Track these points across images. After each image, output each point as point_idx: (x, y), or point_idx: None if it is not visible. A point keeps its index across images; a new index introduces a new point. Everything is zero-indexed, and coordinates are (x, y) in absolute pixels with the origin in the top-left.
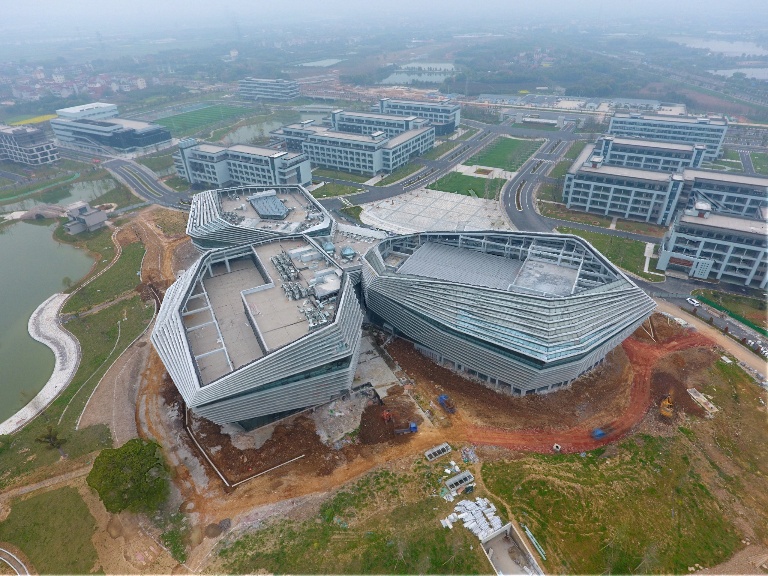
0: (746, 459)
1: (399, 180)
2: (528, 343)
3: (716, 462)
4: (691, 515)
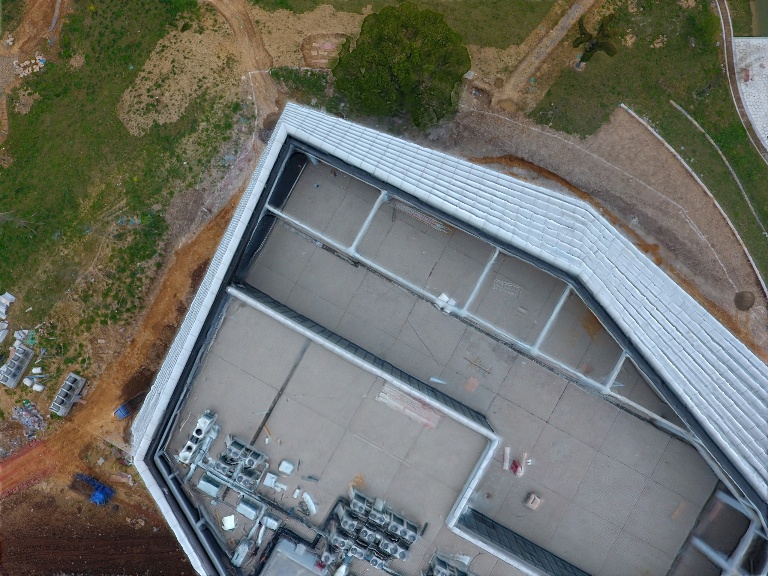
0: None
1: None
2: None
3: None
4: None
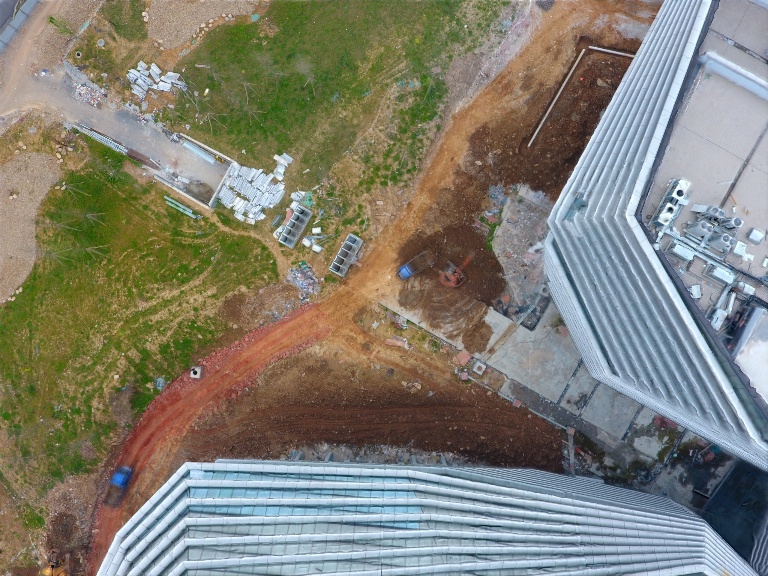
0: None
1: None
2: (234, 495)
3: None
4: (18, 362)
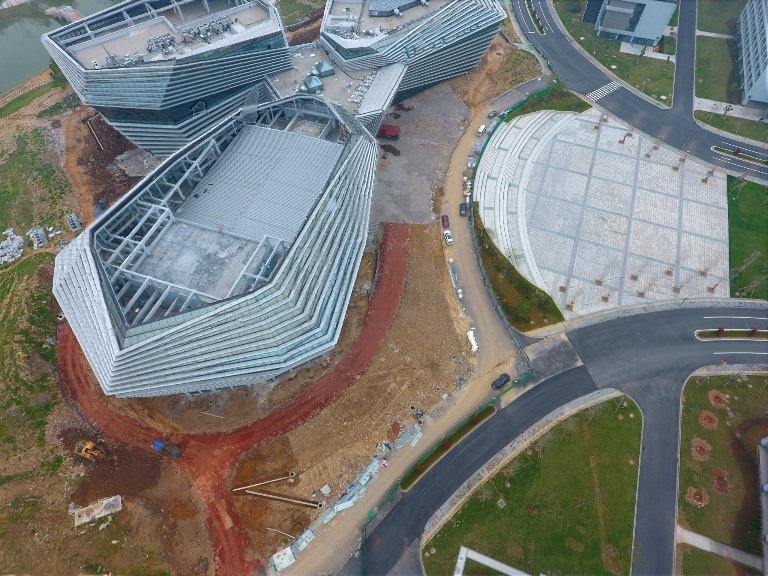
0: (0, 526)
1: (745, 137)
2: None
3: (8, 484)
4: None
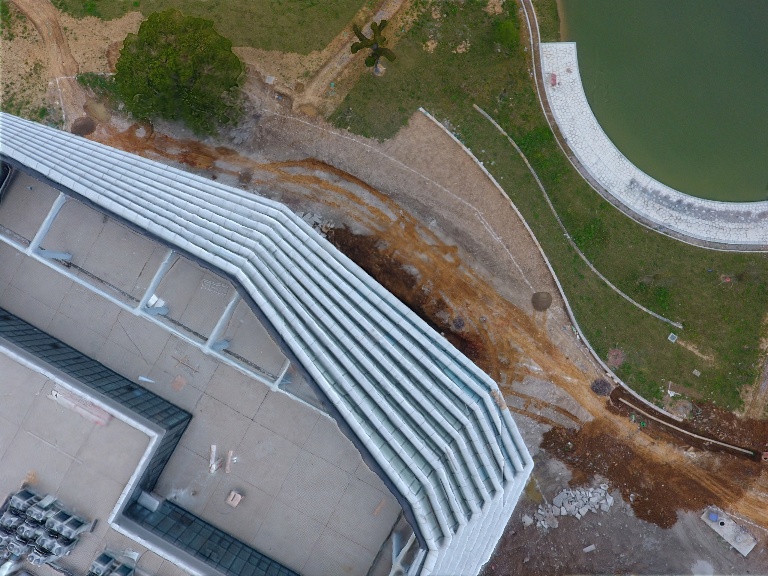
0: None
1: None
2: None
3: None
4: None
